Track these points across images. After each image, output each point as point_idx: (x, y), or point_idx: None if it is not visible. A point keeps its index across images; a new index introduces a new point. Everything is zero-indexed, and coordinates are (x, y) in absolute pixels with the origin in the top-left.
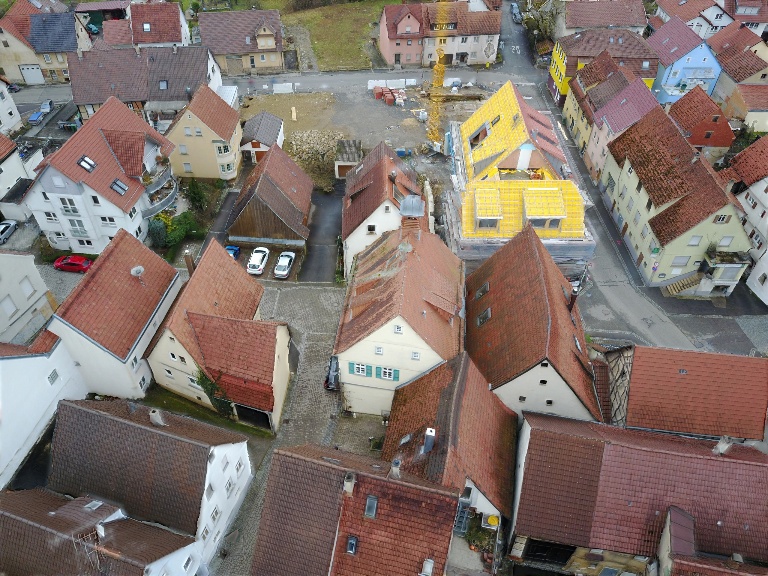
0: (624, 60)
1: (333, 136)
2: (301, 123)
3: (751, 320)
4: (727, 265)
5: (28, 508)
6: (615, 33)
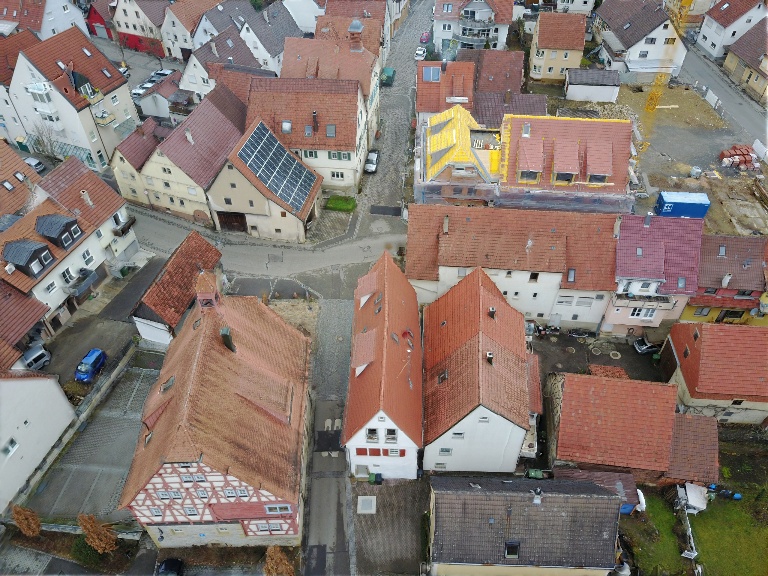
0: None
1: None
2: None
3: None
4: None
5: (238, 2)
6: None
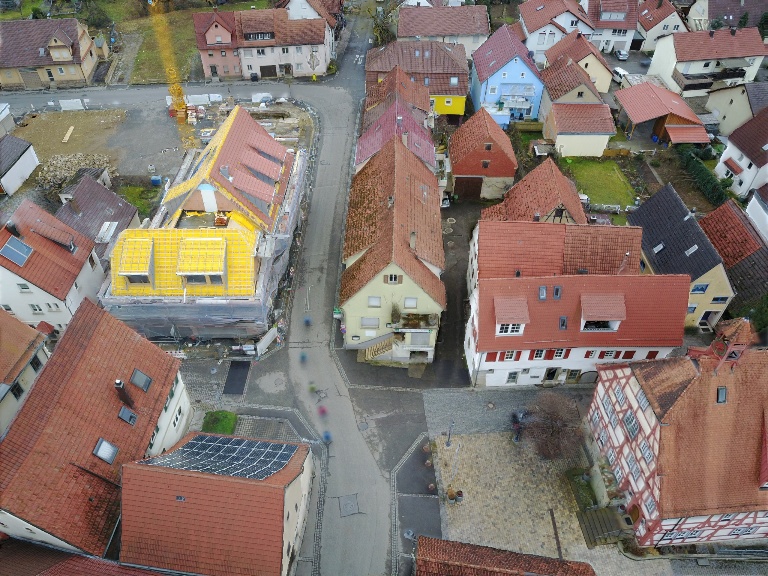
0: (430, 76)
1: (95, 161)
2: (70, 145)
3: (441, 395)
4: (412, 330)
5: None
6: (422, 45)
